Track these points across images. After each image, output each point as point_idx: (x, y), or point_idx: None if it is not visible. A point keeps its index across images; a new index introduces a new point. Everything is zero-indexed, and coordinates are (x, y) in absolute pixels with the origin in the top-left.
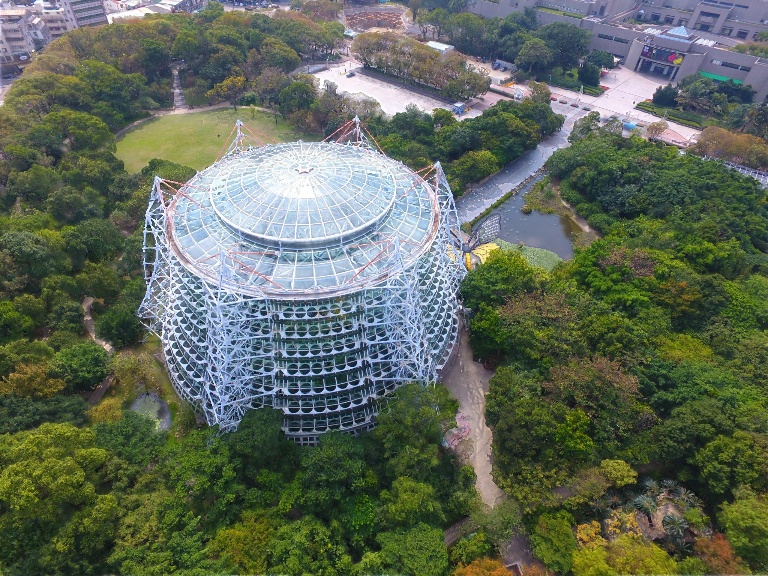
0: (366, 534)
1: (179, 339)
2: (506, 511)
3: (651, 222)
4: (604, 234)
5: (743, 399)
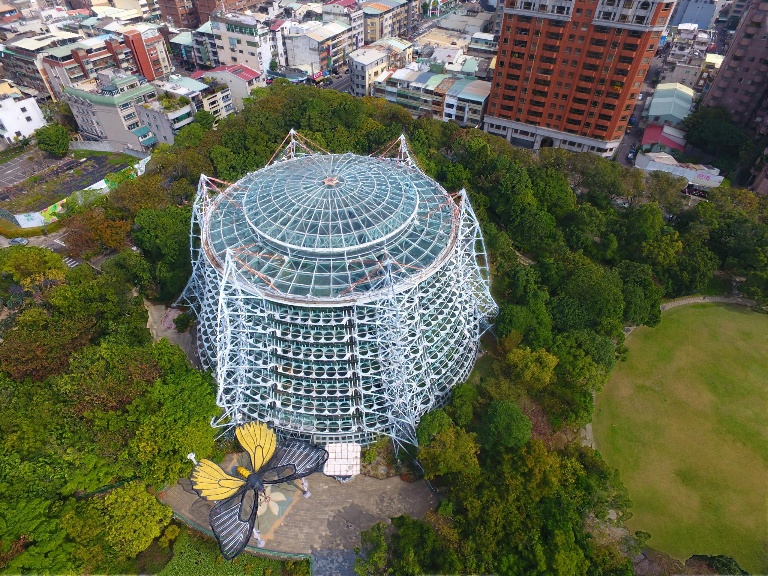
0: None
1: None
2: (113, 268)
3: None
4: None
5: None
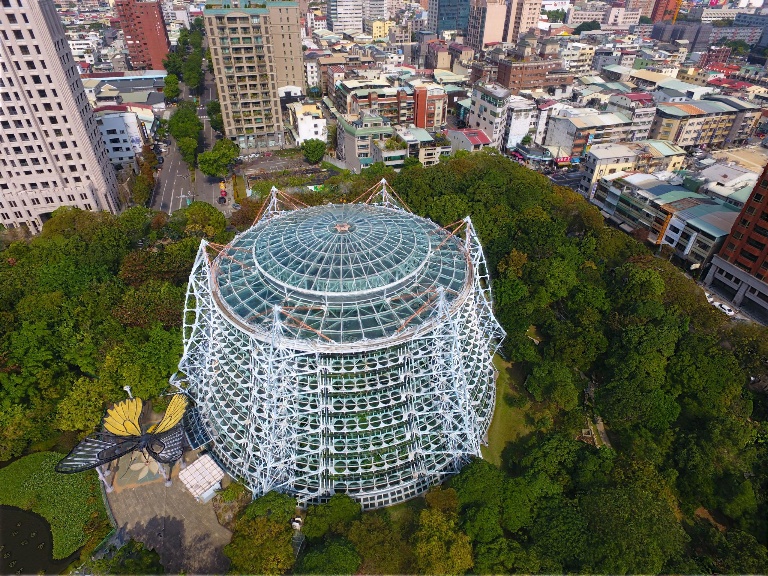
0: None
1: None
2: None
3: None
4: None
5: None
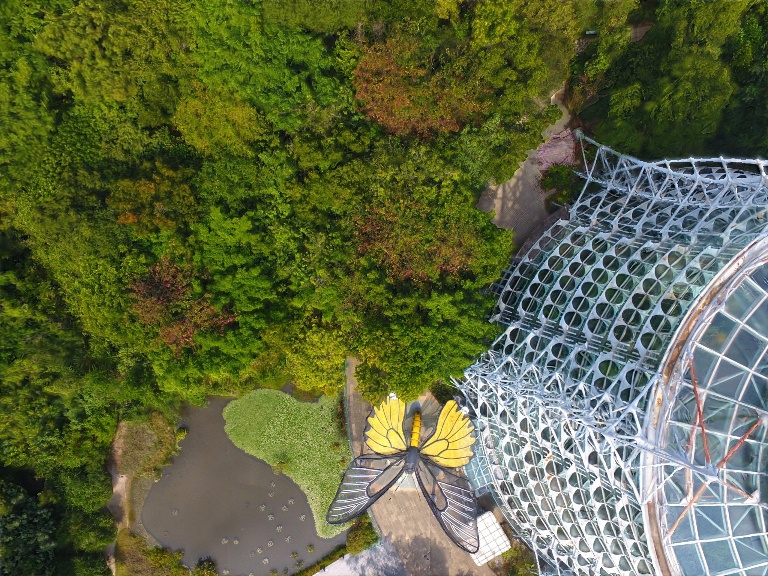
0: (741, 25)
1: None
2: None
3: (8, 434)
4: (105, 452)
5: (220, 8)
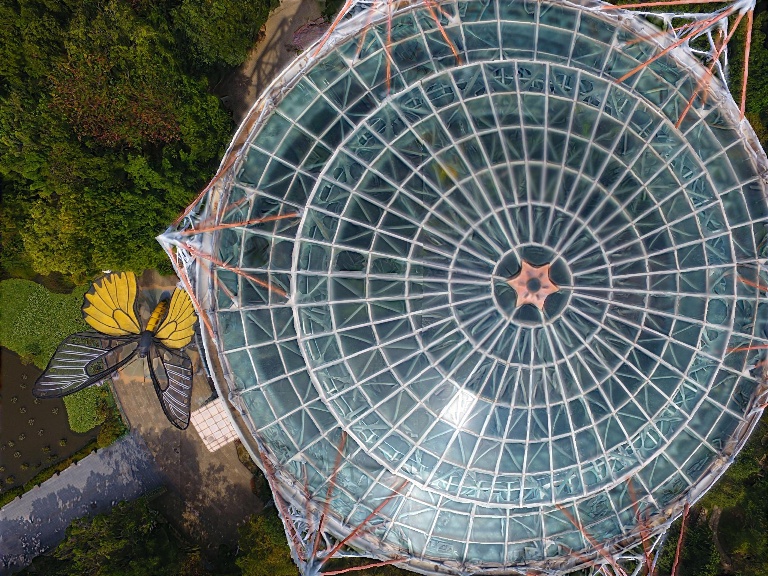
0: None
1: None
2: None
3: None
4: None
5: None
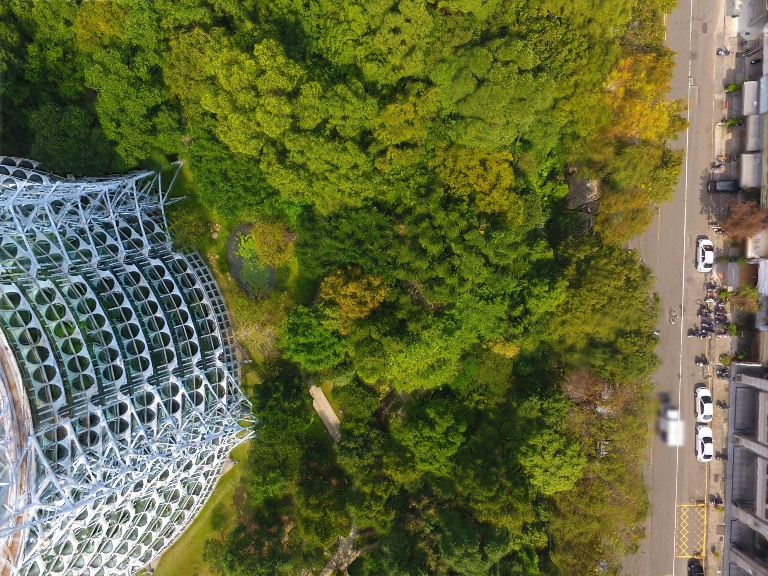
0: None
1: (164, 320)
2: None
3: None
4: None
5: None
